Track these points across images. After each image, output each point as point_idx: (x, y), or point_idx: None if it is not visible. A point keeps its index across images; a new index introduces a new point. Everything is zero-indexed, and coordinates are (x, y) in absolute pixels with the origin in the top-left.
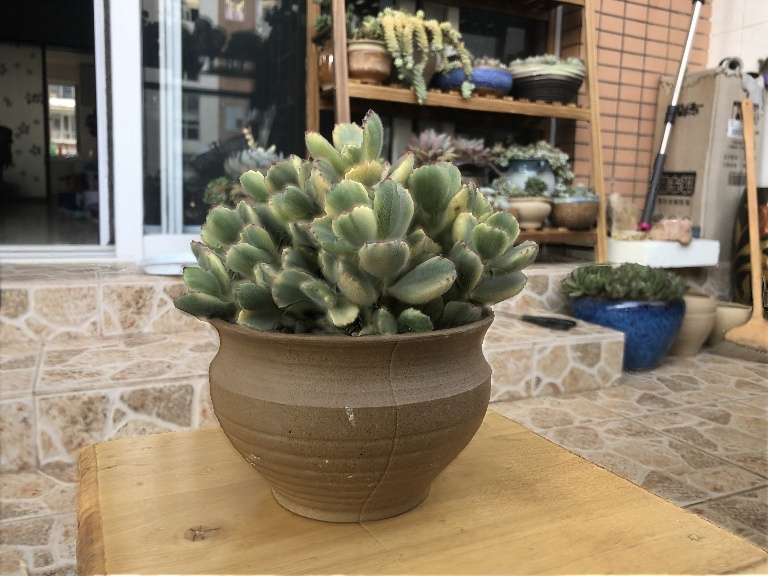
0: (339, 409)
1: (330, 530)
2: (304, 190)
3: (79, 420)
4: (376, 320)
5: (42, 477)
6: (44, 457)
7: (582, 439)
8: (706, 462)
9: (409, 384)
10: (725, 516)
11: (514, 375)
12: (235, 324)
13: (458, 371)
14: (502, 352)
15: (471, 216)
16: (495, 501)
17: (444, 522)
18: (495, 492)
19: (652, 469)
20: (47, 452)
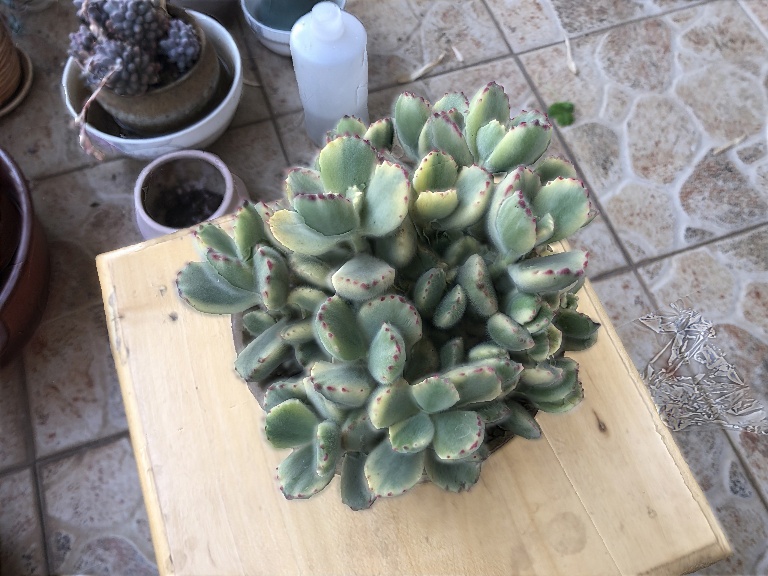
0: None
1: None
2: None
3: None
4: None
5: None
6: None
7: None
8: None
9: None
10: None
11: None
12: None
13: None
14: None
15: (324, 398)
16: None
17: None
18: None
19: None
20: None
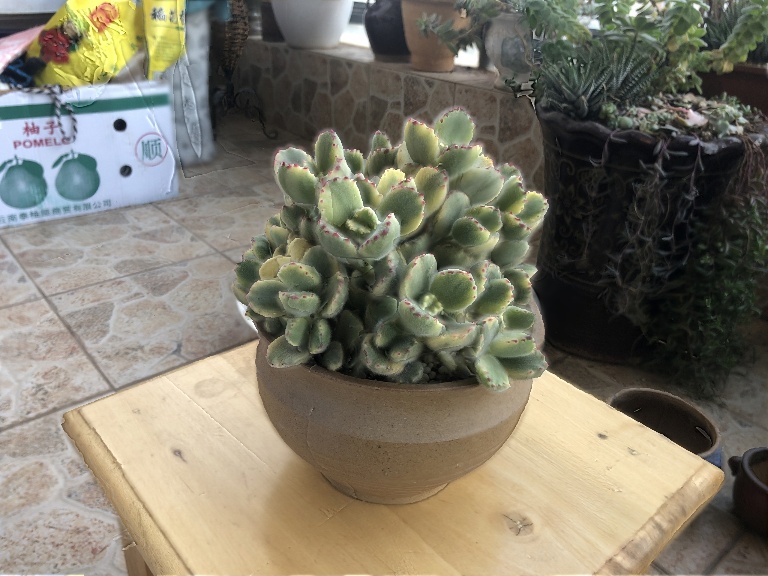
0: None
1: None
2: (439, 207)
3: None
4: None
5: None
6: None
7: None
8: None
9: None
10: None
11: None
12: None
13: None
14: None
15: None
16: None
17: None
18: None
19: None
20: None
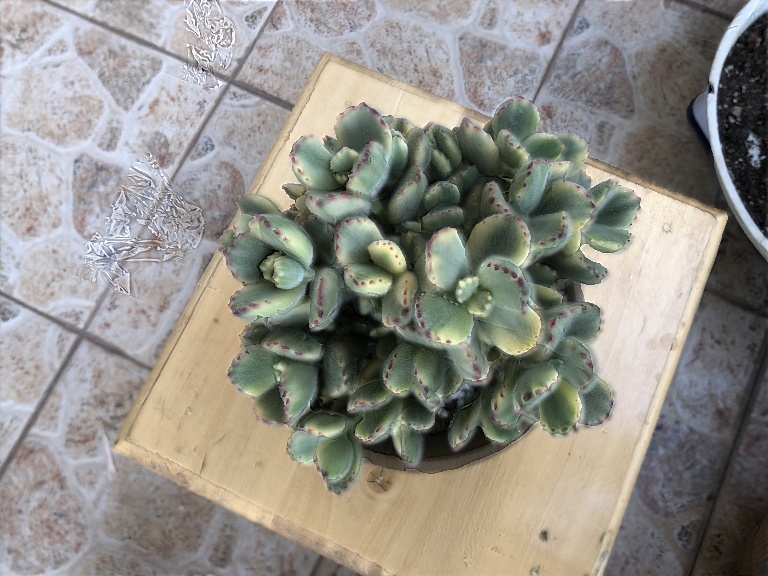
0: None
1: None
2: None
3: None
4: None
5: None
6: None
7: None
8: None
9: None
10: None
11: None
12: (406, 462)
13: None
14: None
15: None
16: None
17: None
18: None
19: None
20: None
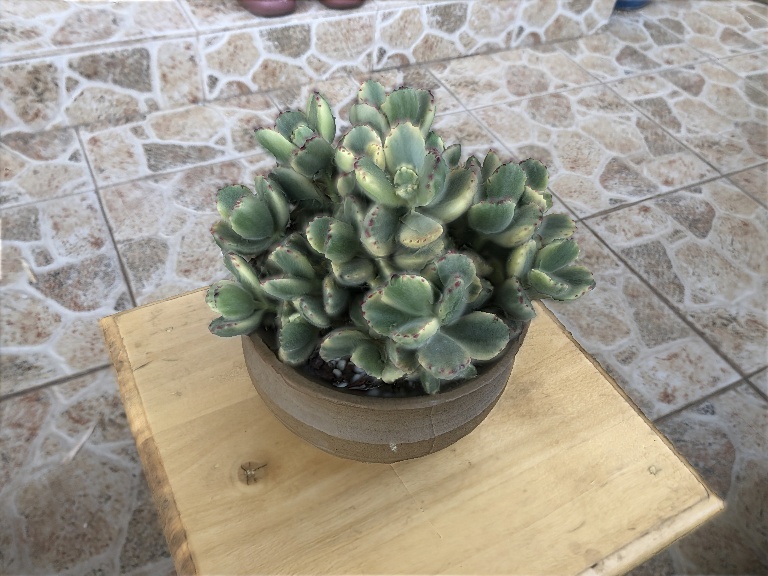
0: (384, 445)
1: (361, 467)
2: None
3: (29, 91)
4: (424, 378)
5: (7, 152)
6: (2, 128)
7: (554, 112)
8: (666, 147)
9: (447, 415)
10: (667, 215)
11: (497, 26)
12: (279, 361)
13: (490, 383)
14: (488, 1)
15: (531, 245)
16: (497, 419)
17: (455, 452)
18: (497, 404)
19: (614, 155)
20: (3, 124)
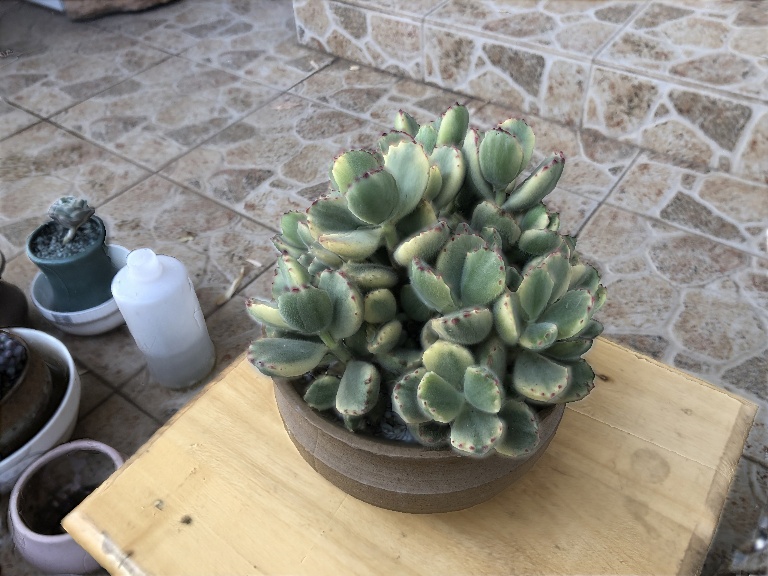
0: None
1: None
2: None
3: (624, 101)
4: None
5: (575, 141)
6: (587, 122)
7: None
8: None
9: (331, 448)
10: None
11: None
12: None
13: (393, 470)
14: None
15: (455, 350)
16: (471, 564)
17: (402, 537)
18: (492, 556)
19: None
20: (590, 119)
